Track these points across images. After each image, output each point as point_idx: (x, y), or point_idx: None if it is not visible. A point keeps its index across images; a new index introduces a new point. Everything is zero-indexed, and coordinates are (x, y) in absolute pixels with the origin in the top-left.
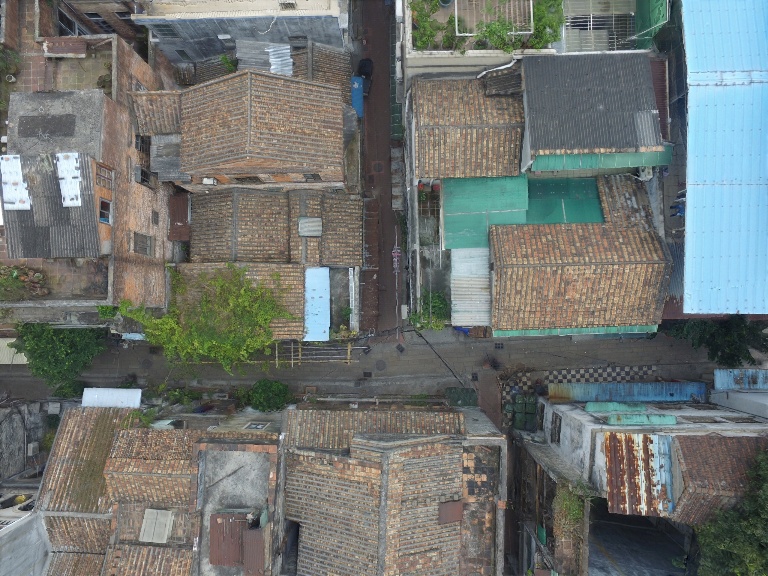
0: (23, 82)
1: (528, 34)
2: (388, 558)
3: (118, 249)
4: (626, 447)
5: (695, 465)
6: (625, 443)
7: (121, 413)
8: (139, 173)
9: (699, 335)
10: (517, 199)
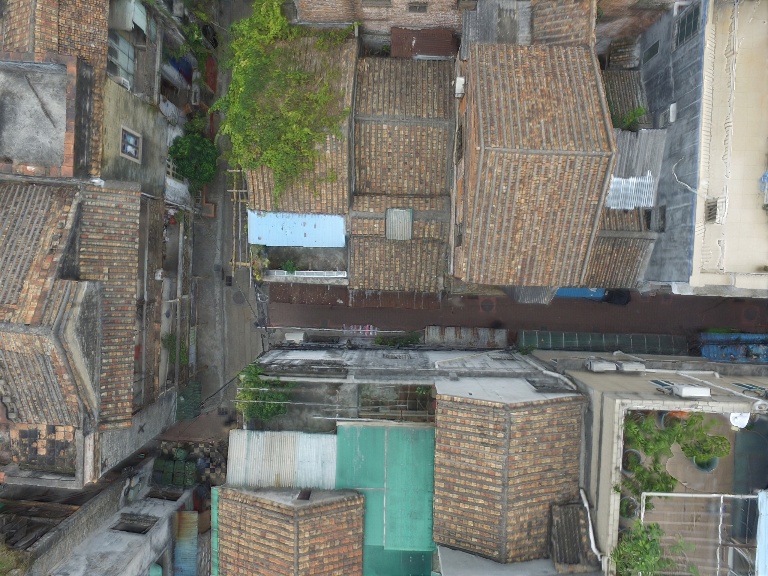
0: None
1: None
2: None
3: None
4: None
5: None
6: None
7: None
8: None
9: None
10: (400, 534)
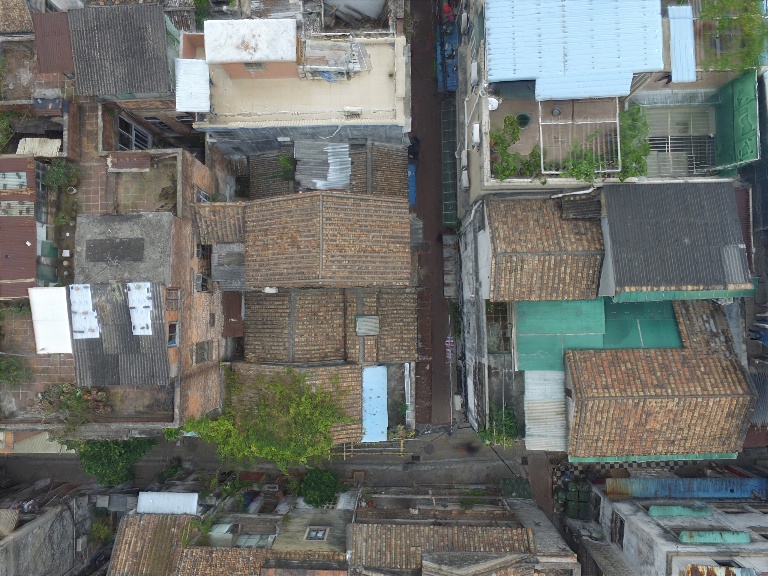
0: (84, 193)
1: (616, 173)
2: None
3: (183, 368)
4: None
5: None
6: None
7: (179, 521)
8: (200, 282)
9: None
10: (593, 322)
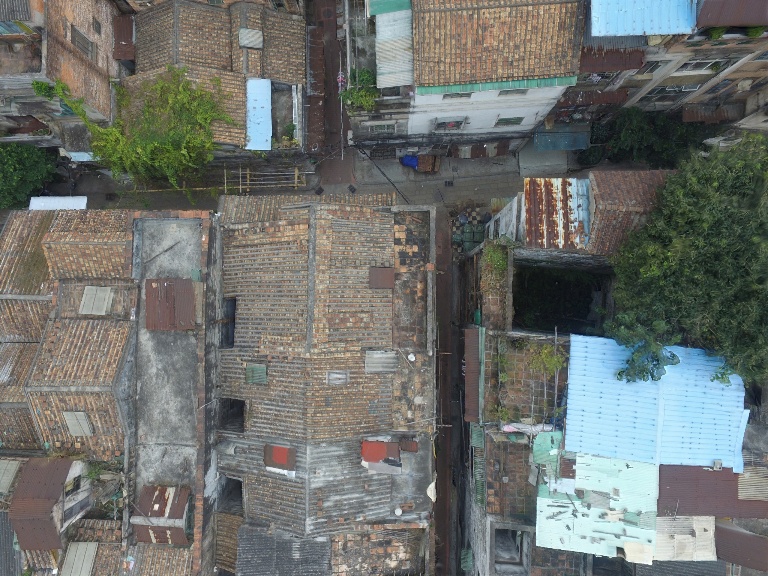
0: None
1: None
2: (317, 311)
3: (52, 28)
4: (545, 190)
5: (607, 190)
6: (544, 187)
7: None
8: None
9: (637, 145)
10: None
